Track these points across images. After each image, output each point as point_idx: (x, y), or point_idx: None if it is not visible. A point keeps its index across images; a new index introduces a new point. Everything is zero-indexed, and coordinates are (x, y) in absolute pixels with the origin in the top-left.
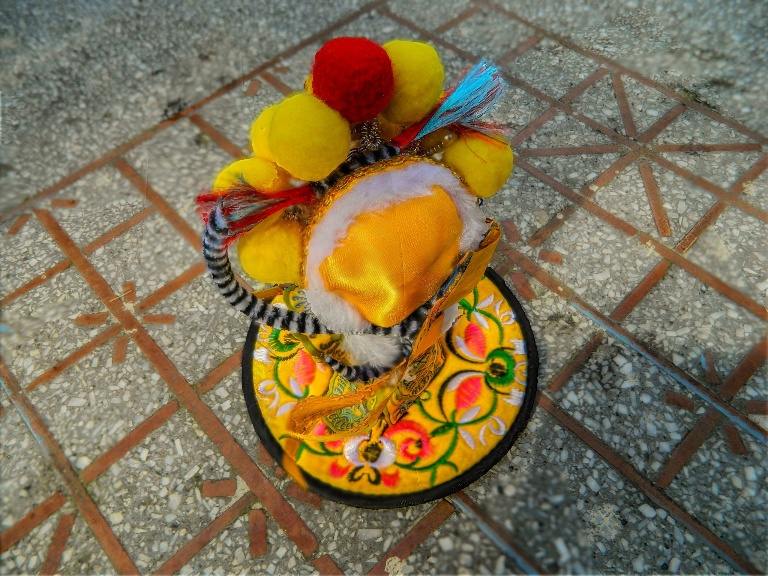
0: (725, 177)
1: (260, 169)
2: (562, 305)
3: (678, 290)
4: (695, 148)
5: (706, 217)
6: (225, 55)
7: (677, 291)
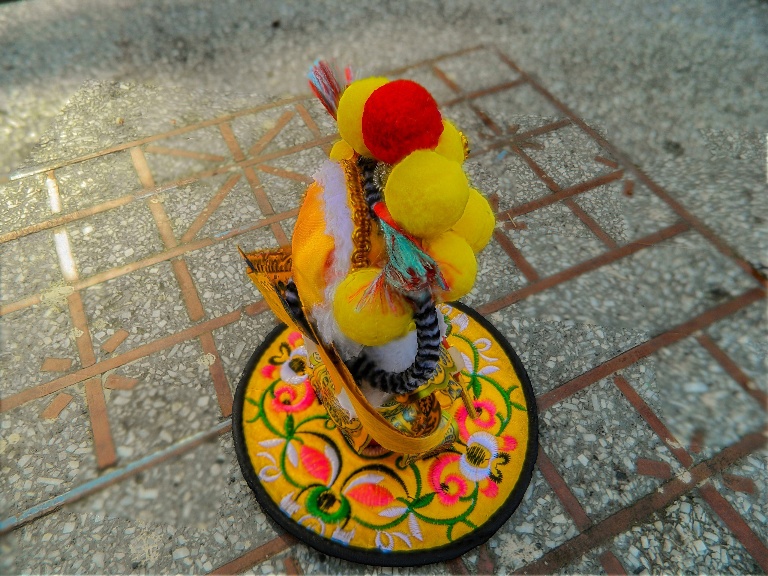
0: None
1: None
2: None
3: None
4: None
5: None
6: None
7: None
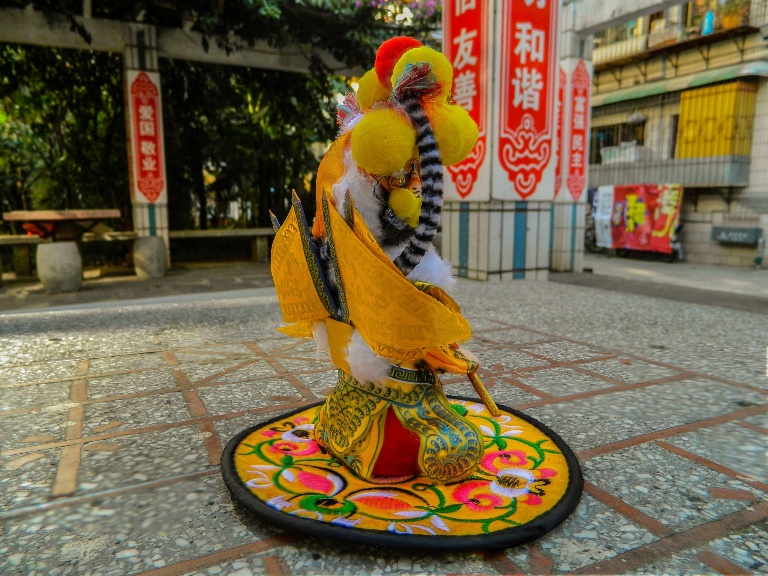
0: None
1: None
2: None
3: None
4: None
5: None
6: None
7: None
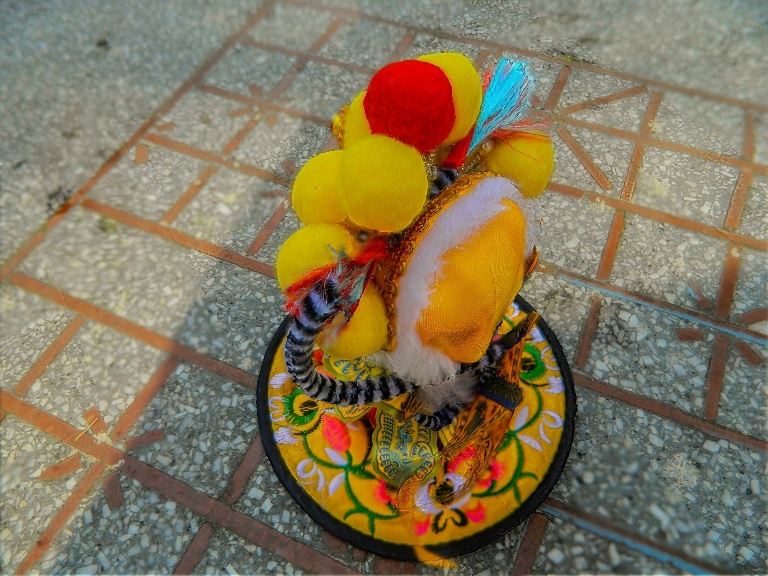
0: (631, 122)
1: (332, 234)
2: (551, 281)
3: (641, 235)
4: (595, 103)
5: (633, 162)
6: (93, 126)
7: (641, 236)
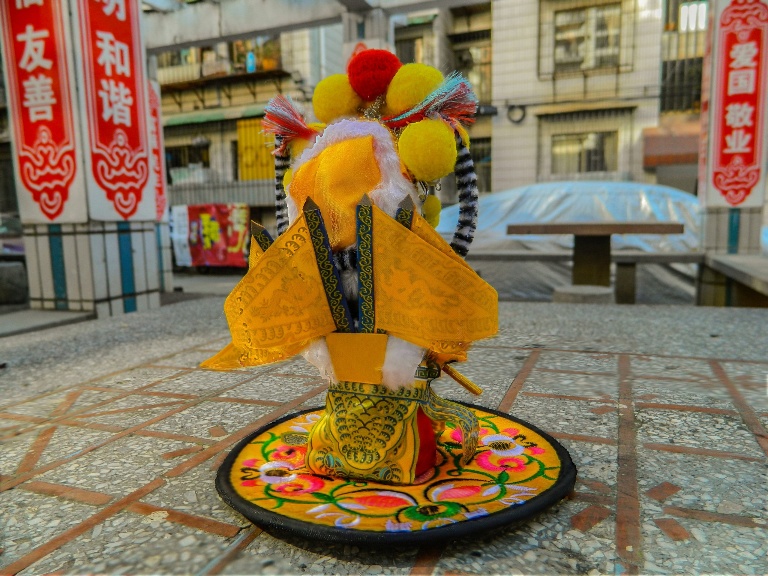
0: None
1: None
2: (602, 555)
3: None
4: None
5: None
6: None
7: None
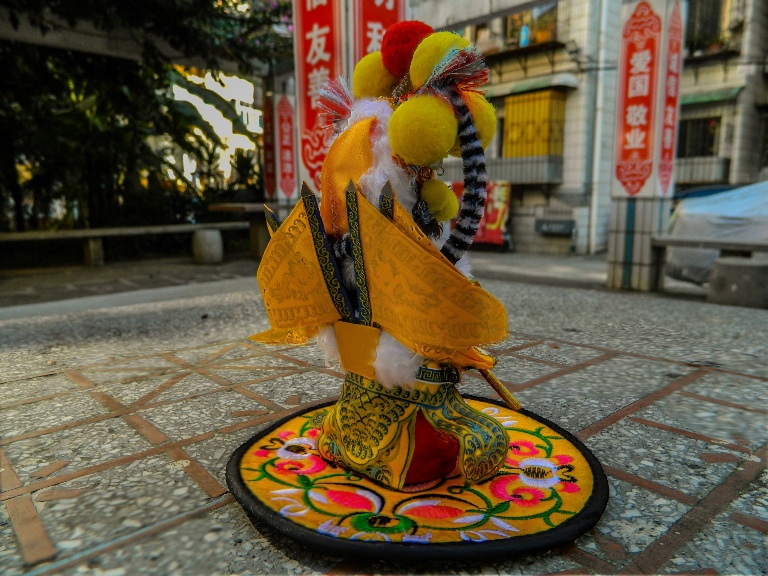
0: None
1: None
2: None
3: None
4: None
5: None
6: None
7: None
